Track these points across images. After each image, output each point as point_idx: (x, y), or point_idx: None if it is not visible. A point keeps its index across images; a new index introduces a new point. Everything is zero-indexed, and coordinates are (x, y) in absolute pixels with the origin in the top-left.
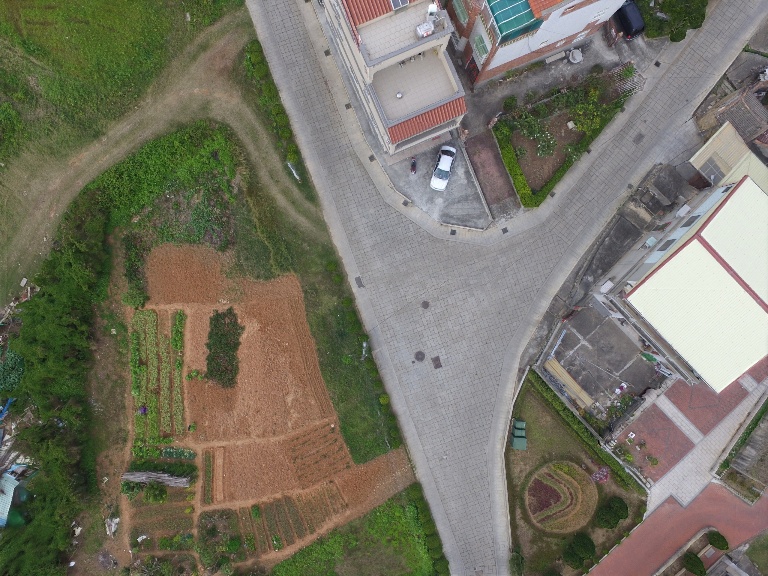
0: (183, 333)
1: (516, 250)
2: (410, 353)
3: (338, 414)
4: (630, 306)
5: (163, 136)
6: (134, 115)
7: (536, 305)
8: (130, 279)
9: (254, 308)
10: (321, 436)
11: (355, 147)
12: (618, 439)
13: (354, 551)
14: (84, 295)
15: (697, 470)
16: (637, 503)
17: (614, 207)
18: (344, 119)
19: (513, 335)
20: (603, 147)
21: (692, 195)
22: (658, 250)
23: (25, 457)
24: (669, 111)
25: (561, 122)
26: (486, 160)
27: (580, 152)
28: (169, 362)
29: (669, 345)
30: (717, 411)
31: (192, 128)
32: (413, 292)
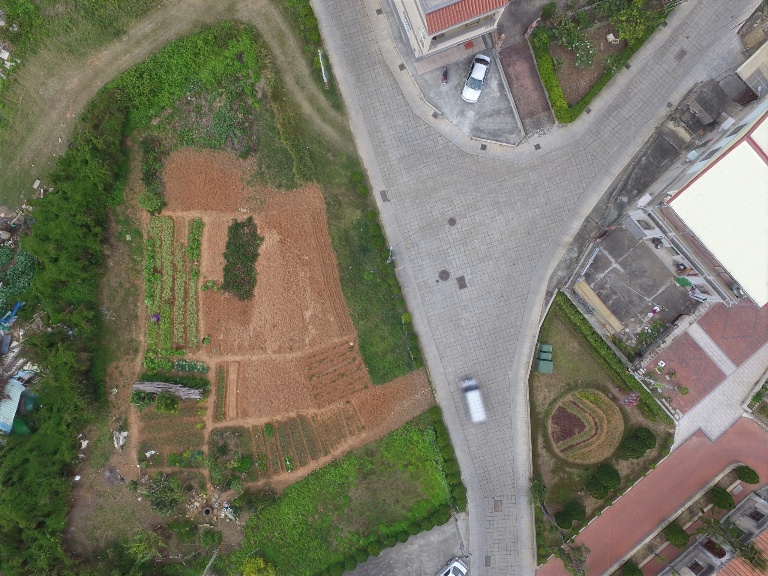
0: (200, 241)
1: (548, 168)
2: (434, 272)
3: (358, 332)
4: (669, 219)
5: (186, 36)
6: (156, 14)
7: (567, 226)
8: (147, 183)
9: (274, 218)
10: (339, 354)
11: (385, 55)
12: (647, 368)
13: (369, 475)
14: (99, 197)
15: (728, 403)
16: (664, 436)
17: (652, 126)
18: (374, 25)
19: (542, 256)
20: (643, 63)
21: (736, 111)
22: (701, 160)
23: (33, 364)
24: (713, 28)
25: (600, 35)
26: (521, 72)
27: (620, 64)
28: (185, 271)
29: (711, 255)
30: (751, 342)
31: (216, 28)
32: (440, 208)
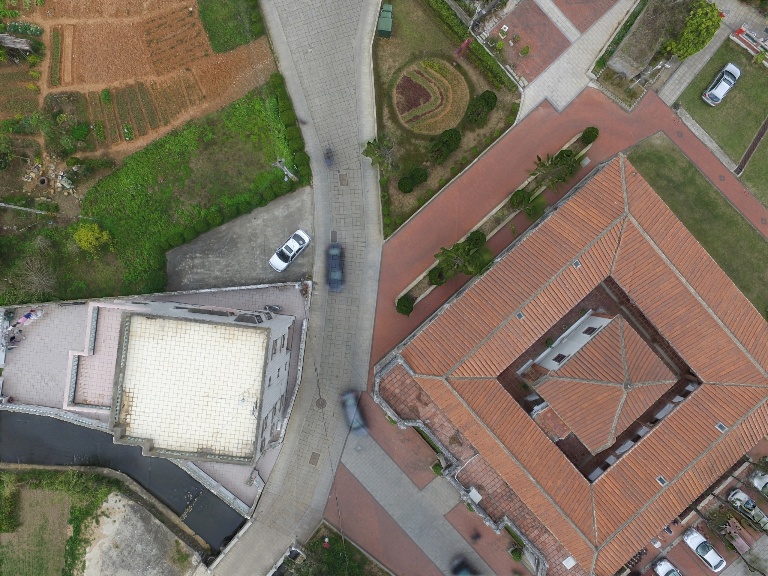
0: None
1: None
2: None
3: None
4: None
5: None
6: None
7: None
8: None
9: None
10: (178, 19)
11: None
12: (491, 33)
13: (210, 145)
14: None
15: (573, 72)
16: (510, 107)
17: None
18: None
19: None
20: None
21: None
22: None
23: None
24: None
25: None
26: None
27: None
28: None
29: None
30: (595, 8)
31: None
32: None
